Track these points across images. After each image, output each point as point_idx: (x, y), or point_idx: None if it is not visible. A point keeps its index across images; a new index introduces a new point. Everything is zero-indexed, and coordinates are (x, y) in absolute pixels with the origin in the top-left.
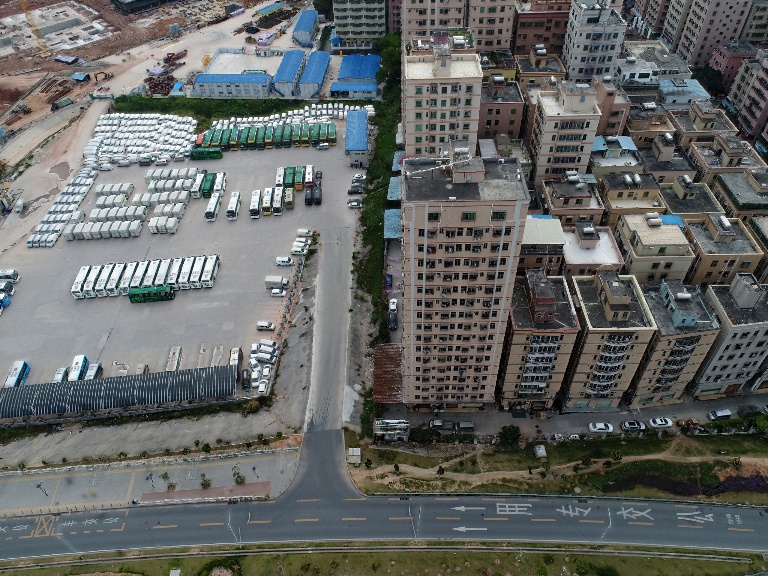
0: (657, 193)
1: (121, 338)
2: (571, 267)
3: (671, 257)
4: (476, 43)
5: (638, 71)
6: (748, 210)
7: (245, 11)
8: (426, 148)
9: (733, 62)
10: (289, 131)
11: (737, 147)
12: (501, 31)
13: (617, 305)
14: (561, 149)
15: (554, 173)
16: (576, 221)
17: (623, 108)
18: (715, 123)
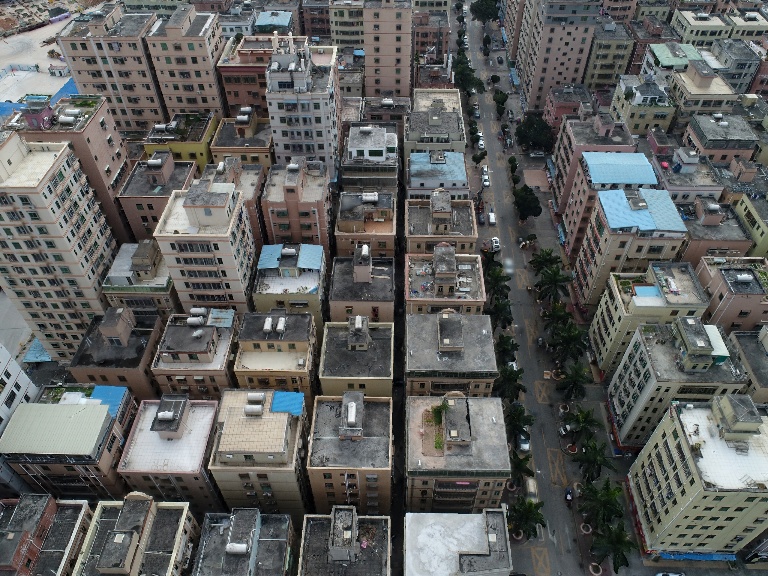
0: (306, 345)
1: None
2: (127, 474)
3: (259, 469)
4: (176, 100)
5: (366, 147)
6: (420, 377)
7: (70, 16)
8: (13, 267)
9: (562, 113)
10: None
11: (445, 272)
12: (202, 87)
13: (109, 575)
14: (194, 274)
15: (201, 300)
16: (164, 395)
17: (313, 207)
18: (449, 225)
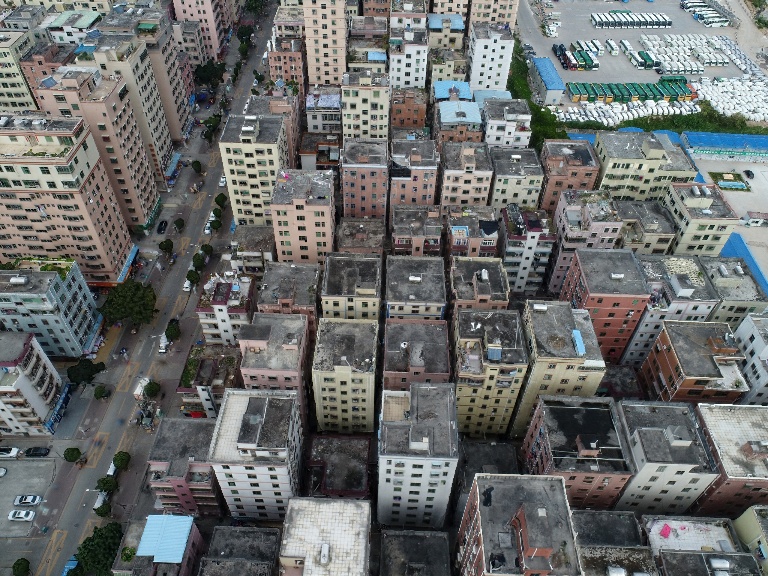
0: None
1: (618, 8)
2: None
3: None
4: None
5: None
6: None
7: None
8: None
9: None
10: (613, 88)
11: None
12: None
13: None
14: None
15: None
16: None
17: None
18: None
